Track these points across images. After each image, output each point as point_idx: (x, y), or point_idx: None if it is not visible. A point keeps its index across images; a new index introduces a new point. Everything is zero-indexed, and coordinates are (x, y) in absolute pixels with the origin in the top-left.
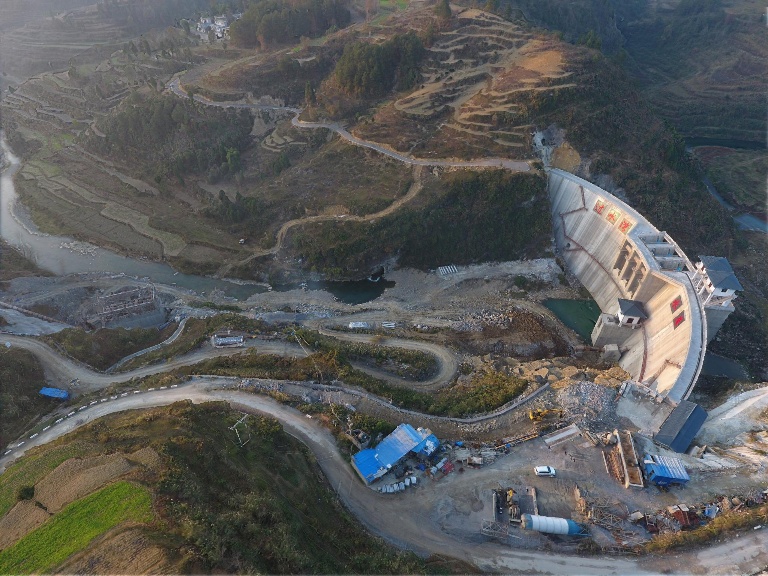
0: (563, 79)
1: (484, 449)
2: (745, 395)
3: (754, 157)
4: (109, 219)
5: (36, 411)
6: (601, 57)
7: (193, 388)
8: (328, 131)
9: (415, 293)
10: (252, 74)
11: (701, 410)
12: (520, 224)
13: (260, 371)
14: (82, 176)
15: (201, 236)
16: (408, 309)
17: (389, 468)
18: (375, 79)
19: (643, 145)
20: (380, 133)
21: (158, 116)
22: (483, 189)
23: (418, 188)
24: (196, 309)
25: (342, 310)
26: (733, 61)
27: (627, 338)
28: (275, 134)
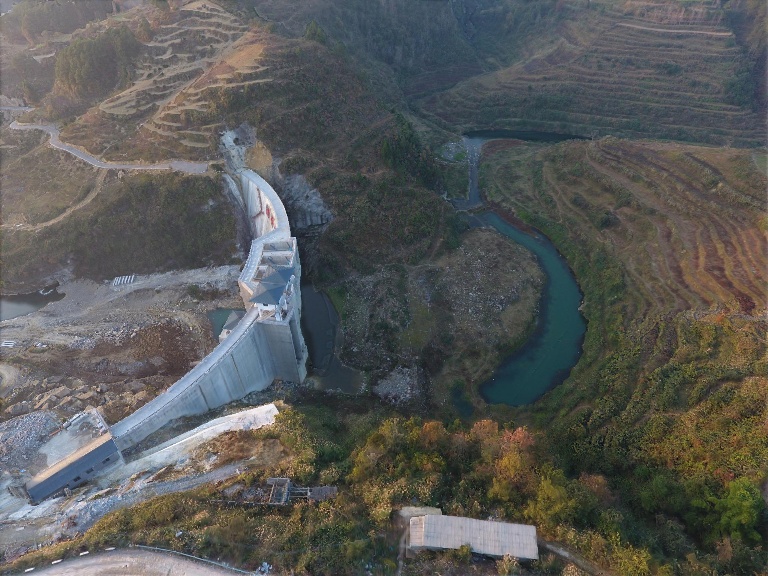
0: (255, 74)
1: None
2: (212, 422)
3: (537, 150)
4: None
5: None
6: (315, 50)
7: None
8: (41, 133)
9: (76, 306)
10: None
11: (111, 445)
12: (201, 230)
13: None
14: None
15: None
16: (48, 325)
17: None
18: (89, 76)
19: (354, 142)
20: (78, 135)
21: None
22: (157, 193)
23: (95, 194)
24: None
25: None
26: (551, 49)
27: None
28: None
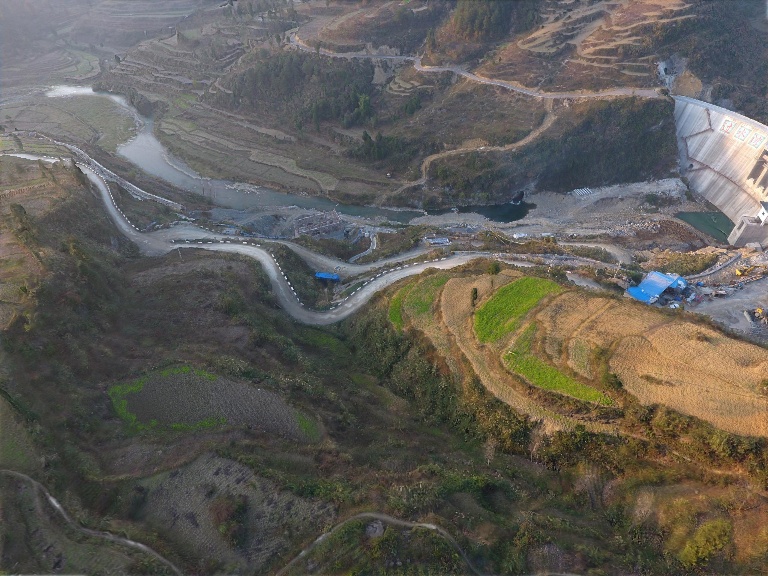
0: (684, 10)
1: (722, 287)
2: None
3: None
4: (260, 163)
5: (322, 287)
6: None
7: (460, 259)
8: (452, 74)
9: (557, 212)
10: (370, 26)
11: None
12: (648, 147)
13: (497, 252)
14: (218, 129)
15: (350, 173)
16: (558, 223)
17: (657, 297)
18: (495, 22)
19: (757, 71)
20: (508, 71)
21: (288, 69)
22: (615, 116)
23: (552, 119)
24: (377, 228)
25: (498, 227)
26: None
27: (766, 237)
28: (399, 80)
